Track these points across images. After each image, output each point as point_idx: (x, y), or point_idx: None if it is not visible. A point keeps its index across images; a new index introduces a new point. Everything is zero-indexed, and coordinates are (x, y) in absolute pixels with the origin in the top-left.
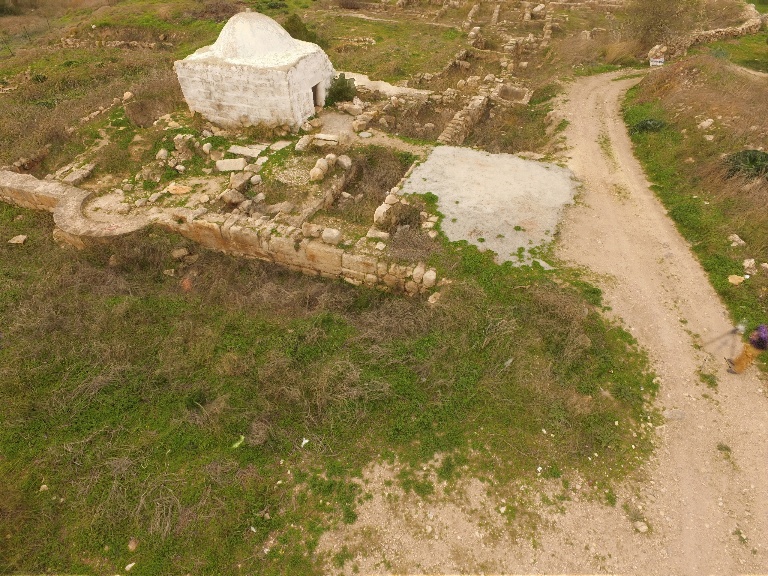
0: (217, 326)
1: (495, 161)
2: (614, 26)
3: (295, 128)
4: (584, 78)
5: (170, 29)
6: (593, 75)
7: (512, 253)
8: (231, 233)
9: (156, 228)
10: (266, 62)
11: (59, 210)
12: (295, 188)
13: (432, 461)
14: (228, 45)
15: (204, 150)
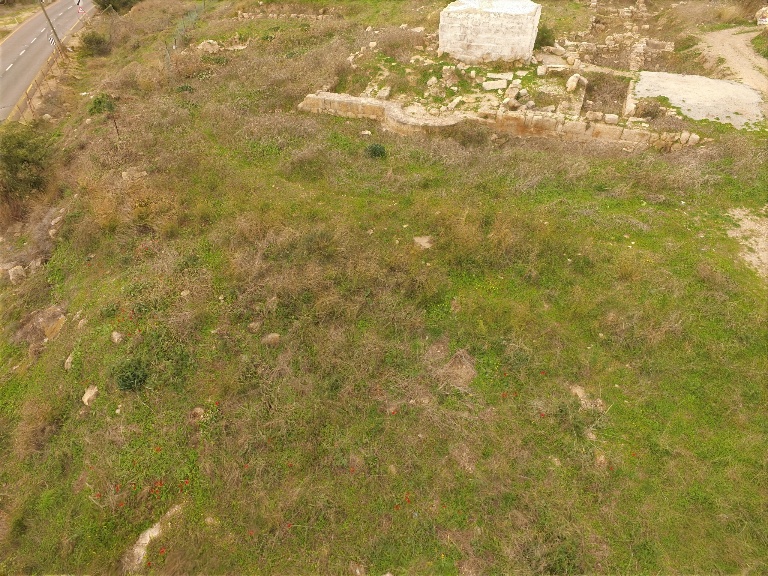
0: None
1: (691, 79)
2: None
3: (528, 62)
4: (710, 33)
5: (328, 4)
6: (715, 31)
7: (742, 125)
8: (534, 121)
9: (468, 122)
10: (515, 11)
11: (391, 113)
12: (558, 96)
13: (766, 207)
14: None
15: (472, 75)
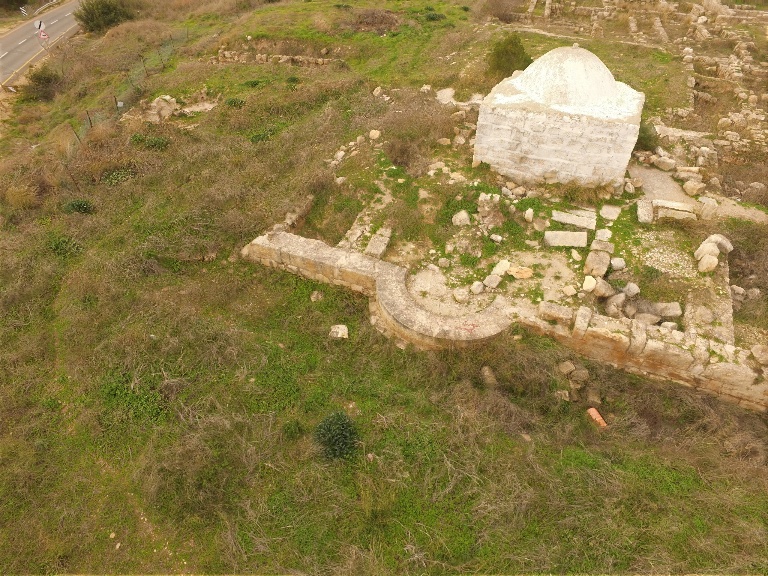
0: (761, 523)
1: None
2: None
3: (619, 189)
4: None
5: (333, 43)
6: None
7: None
8: (648, 350)
9: (520, 328)
10: (605, 111)
11: (385, 295)
12: (683, 281)
13: None
14: (553, 88)
15: (527, 217)
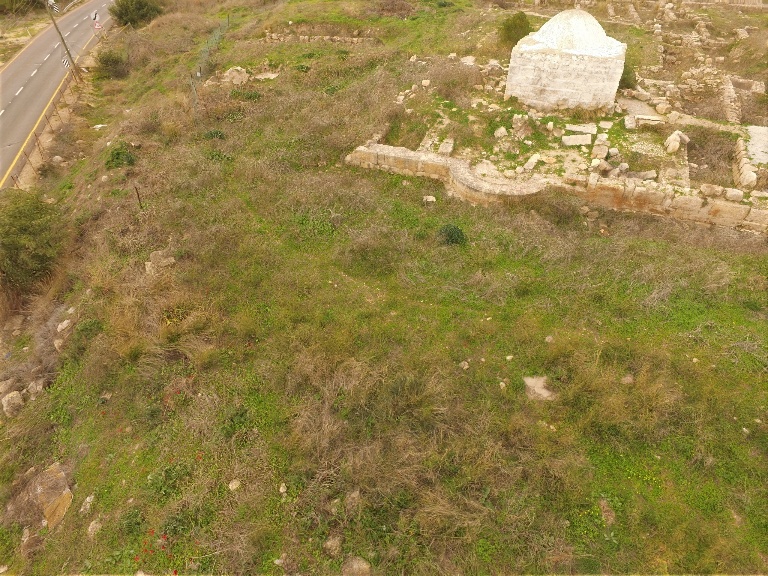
0: None
1: None
2: (760, 25)
3: (611, 110)
4: None
5: (364, 25)
6: None
7: None
8: (636, 193)
9: (552, 190)
10: (600, 53)
11: (458, 175)
12: (657, 158)
13: None
14: (563, 38)
15: (549, 127)
